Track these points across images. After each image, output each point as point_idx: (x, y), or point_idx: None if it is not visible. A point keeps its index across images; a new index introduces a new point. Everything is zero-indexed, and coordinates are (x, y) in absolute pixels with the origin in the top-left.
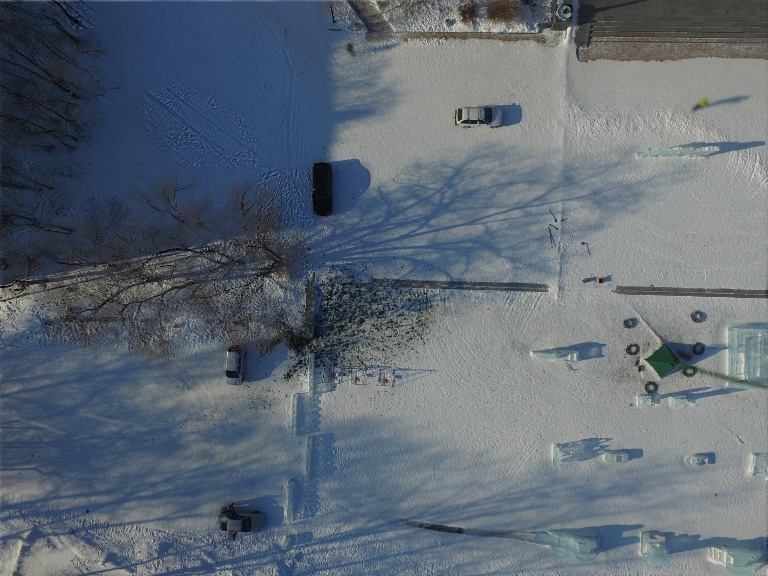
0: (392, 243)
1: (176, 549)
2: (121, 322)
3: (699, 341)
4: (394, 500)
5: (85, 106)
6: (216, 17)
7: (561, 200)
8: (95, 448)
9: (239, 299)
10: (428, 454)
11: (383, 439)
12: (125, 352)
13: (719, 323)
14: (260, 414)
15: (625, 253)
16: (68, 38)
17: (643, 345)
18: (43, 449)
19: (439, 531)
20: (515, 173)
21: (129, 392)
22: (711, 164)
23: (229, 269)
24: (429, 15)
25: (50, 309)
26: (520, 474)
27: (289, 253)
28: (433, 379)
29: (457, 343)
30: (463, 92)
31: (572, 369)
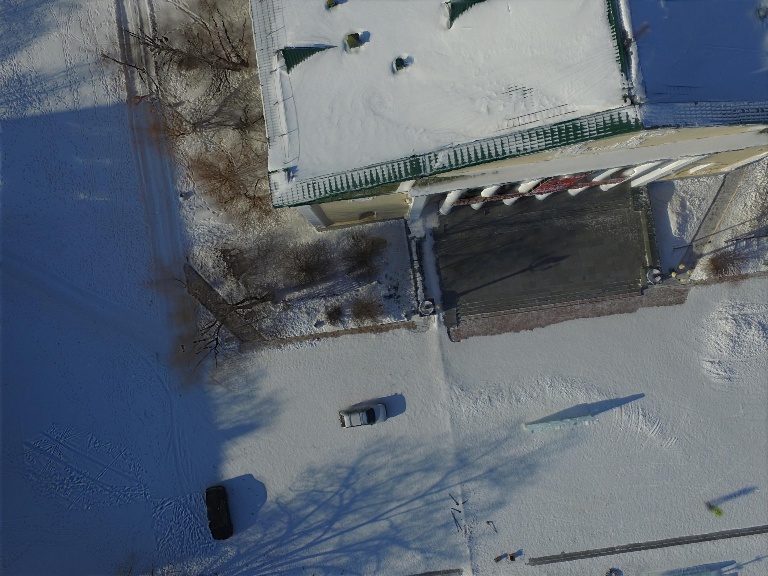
0: (299, 553)
1: None
2: None
3: None
4: None
5: None
6: (84, 354)
7: (459, 483)
8: None
9: None
10: None
11: None
12: None
13: None
14: None
15: (531, 525)
16: None
17: None
18: None
19: None
20: (409, 463)
21: None
22: None
23: None
24: (298, 320)
25: None
26: None
27: None
28: None
29: None
30: (344, 390)
31: None
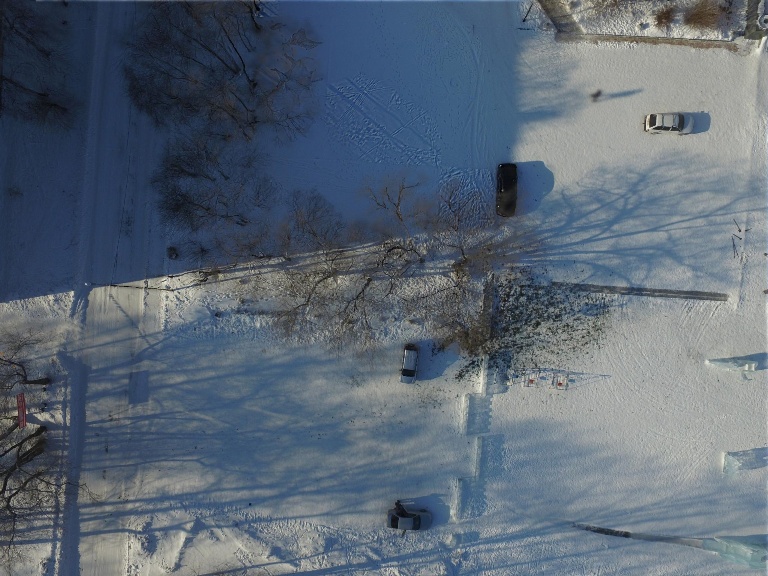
0: (573, 247)
1: (341, 545)
2: (294, 316)
3: None
4: (562, 503)
5: (294, 98)
6: (403, 11)
7: (746, 210)
8: (260, 442)
9: (415, 297)
10: (598, 458)
11: (553, 442)
12: (294, 346)
13: None
14: (429, 413)
15: None
16: (254, 26)
17: None
18: (206, 441)
19: (606, 534)
20: (701, 181)
21: (296, 387)
22: None
23: (408, 267)
24: (621, 18)
25: (221, 301)
26: (689, 481)
27: (471, 253)
28: (606, 384)
29: (633, 349)
30: (652, 98)
31: (747, 379)
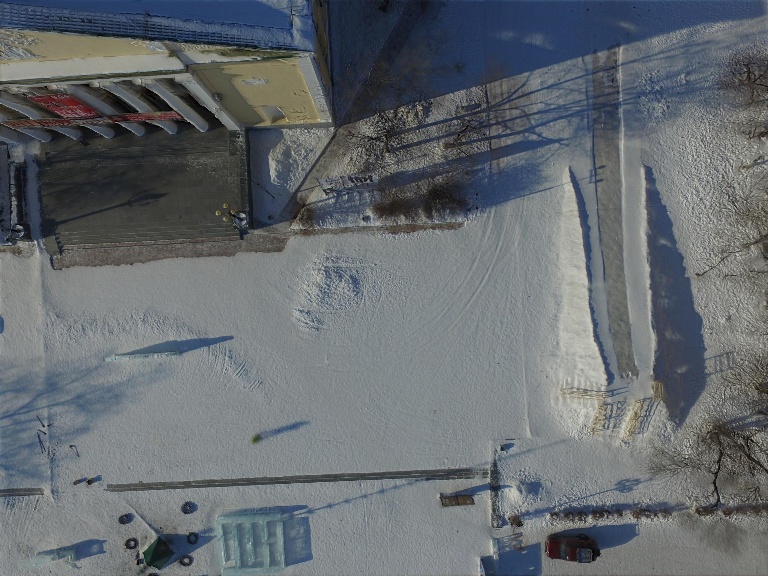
0: None
1: None
2: None
3: (193, 531)
4: None
5: None
6: None
7: (46, 406)
8: None
9: None
10: None
11: None
12: None
13: (209, 512)
14: None
15: (112, 452)
16: None
17: (141, 539)
18: None
19: None
20: (2, 382)
21: None
22: (185, 361)
23: None
24: None
25: None
26: None
27: None
28: None
29: None
30: None
31: (76, 567)
